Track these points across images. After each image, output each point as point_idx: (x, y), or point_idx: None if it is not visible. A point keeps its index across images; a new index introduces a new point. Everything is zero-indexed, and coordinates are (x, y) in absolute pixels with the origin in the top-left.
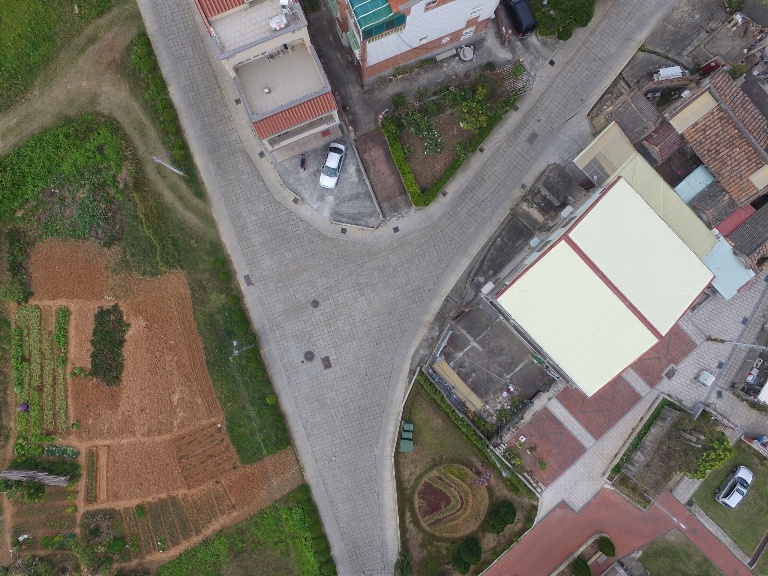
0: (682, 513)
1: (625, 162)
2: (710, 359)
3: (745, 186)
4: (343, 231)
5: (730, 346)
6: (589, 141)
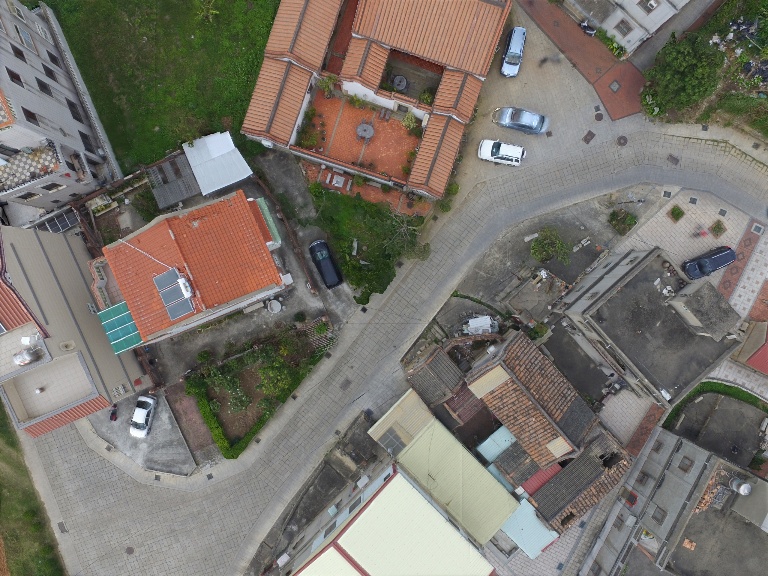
0: None
1: (422, 430)
2: None
3: (544, 452)
4: (157, 478)
5: None
6: (403, 387)
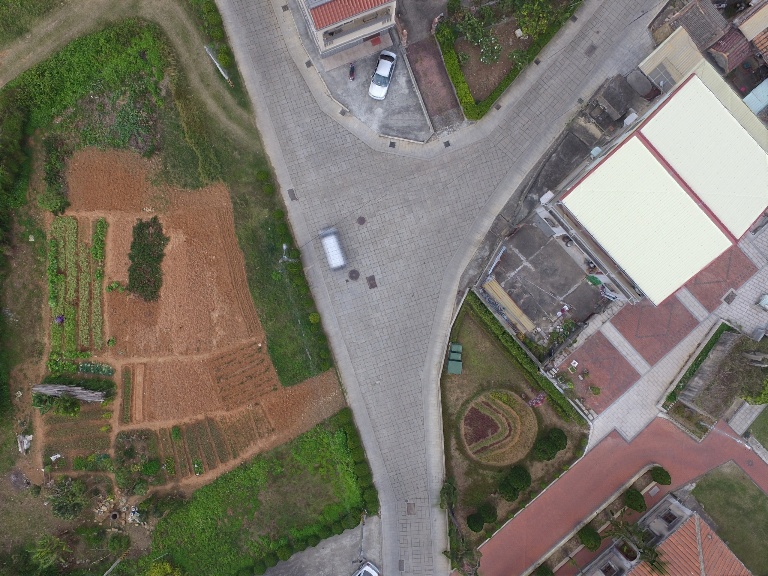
0: (738, 445)
1: (692, 69)
2: None
3: None
4: (392, 145)
5: None
6: None
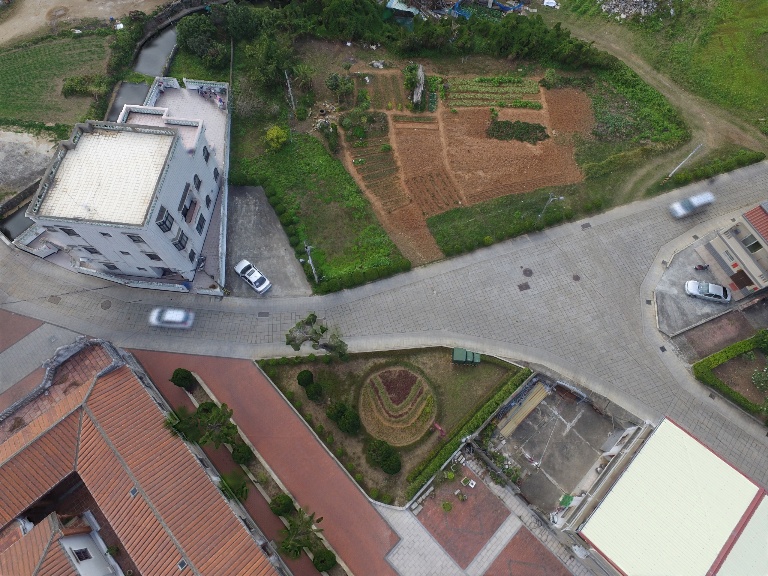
0: None
1: None
2: None
3: None
4: (648, 302)
5: None
6: None
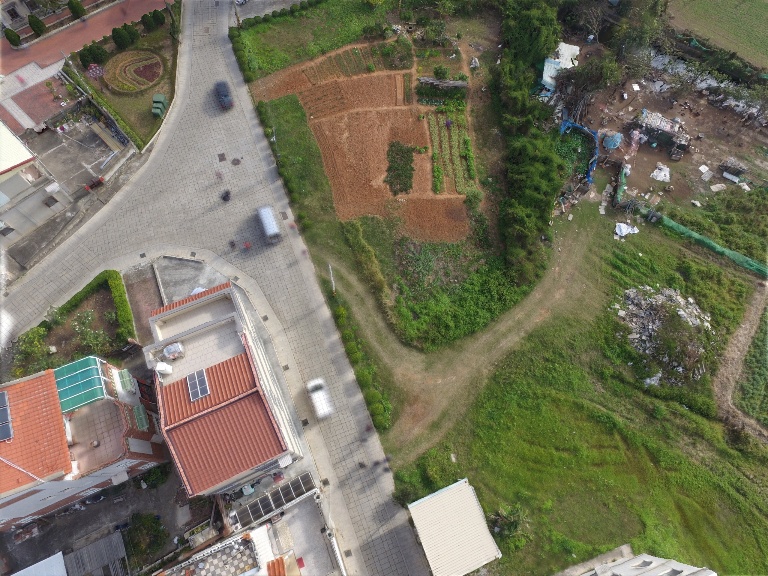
0: None
1: None
2: None
3: None
4: (194, 254)
5: None
6: None
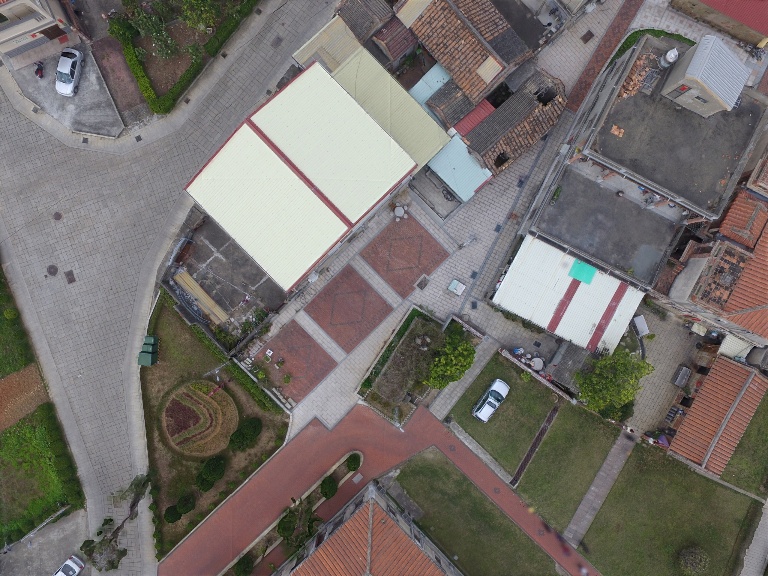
0: (440, 430)
1: (349, 57)
2: (463, 269)
3: (475, 81)
4: (85, 141)
5: (484, 255)
6: None
